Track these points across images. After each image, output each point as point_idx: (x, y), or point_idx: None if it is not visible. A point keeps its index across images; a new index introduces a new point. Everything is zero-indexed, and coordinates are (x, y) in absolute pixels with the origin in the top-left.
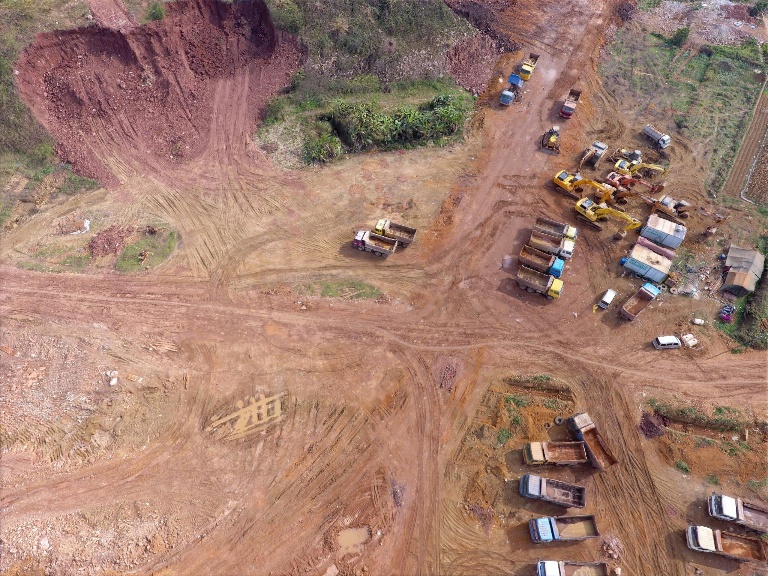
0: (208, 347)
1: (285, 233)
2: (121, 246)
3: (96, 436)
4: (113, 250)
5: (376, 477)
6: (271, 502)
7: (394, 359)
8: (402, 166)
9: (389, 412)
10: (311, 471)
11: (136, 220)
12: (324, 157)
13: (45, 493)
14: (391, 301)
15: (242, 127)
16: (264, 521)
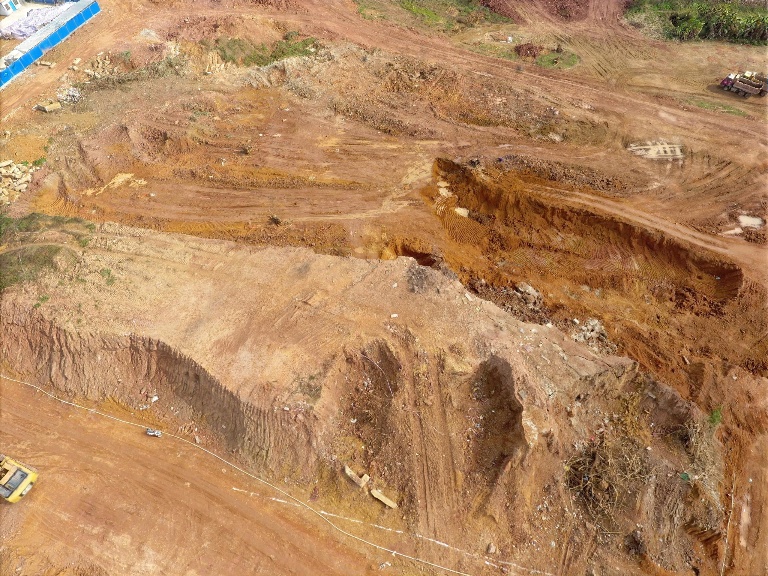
0: (618, 113)
1: (660, 71)
2: (538, 54)
3: (551, 135)
4: (533, 55)
5: (763, 198)
6: (685, 191)
7: (766, 148)
8: (750, 54)
9: (767, 171)
10: (711, 184)
11: (544, 44)
12: (685, 36)
13: (530, 148)
14: (757, 120)
15: (613, 10)
16: (682, 197)
